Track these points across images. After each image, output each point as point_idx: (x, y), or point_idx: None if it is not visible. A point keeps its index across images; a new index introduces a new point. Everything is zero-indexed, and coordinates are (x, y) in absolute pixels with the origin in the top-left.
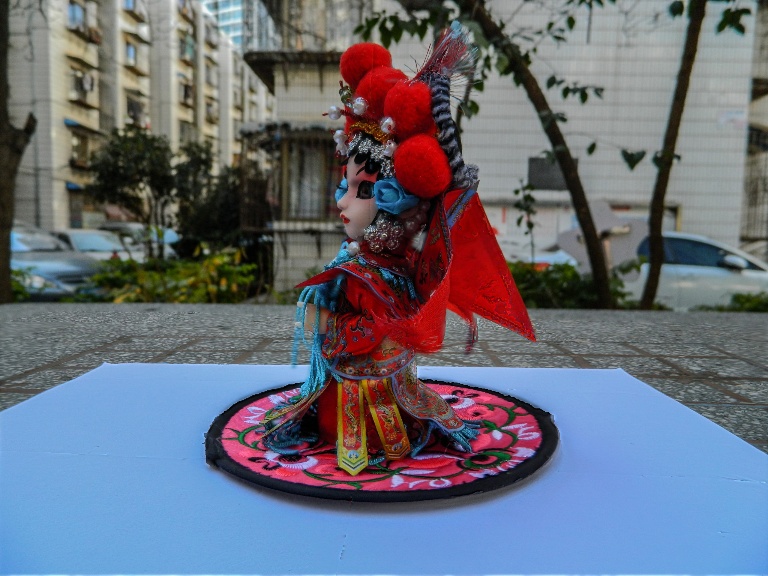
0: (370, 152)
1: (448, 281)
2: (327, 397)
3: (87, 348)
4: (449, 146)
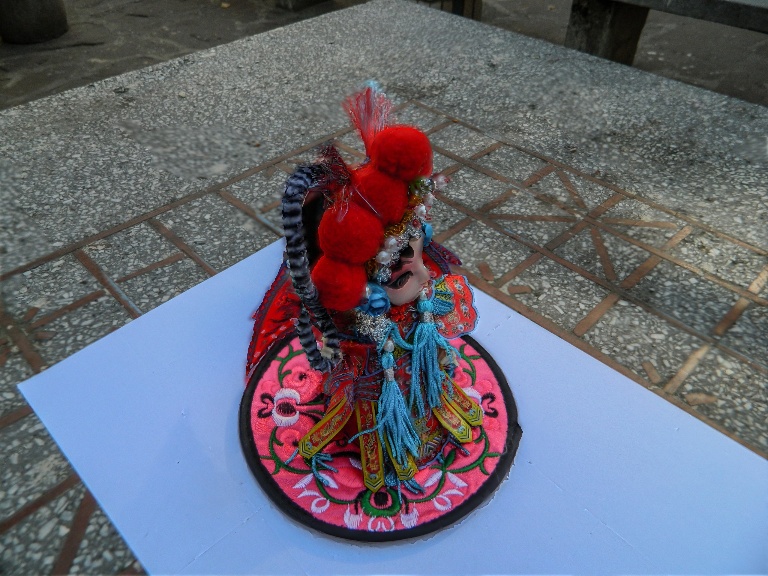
0: None
1: None
2: None
3: None
4: None
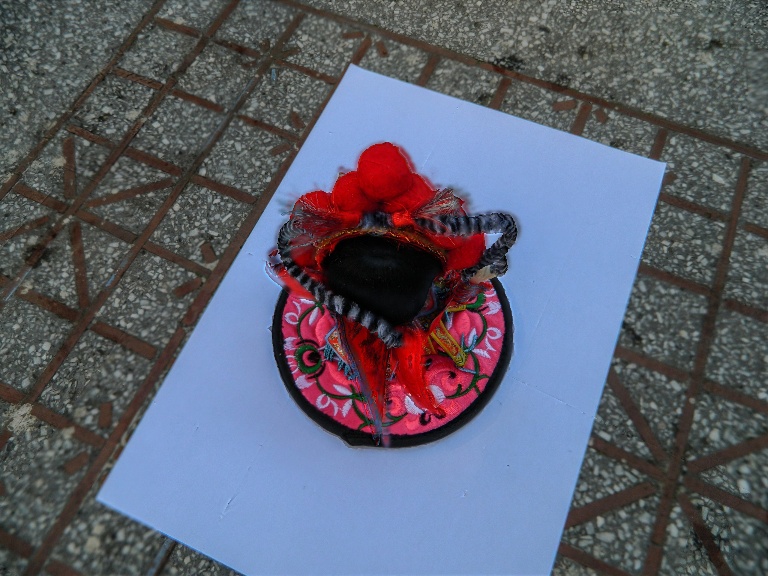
0: None
1: None
2: None
3: (763, 145)
4: None
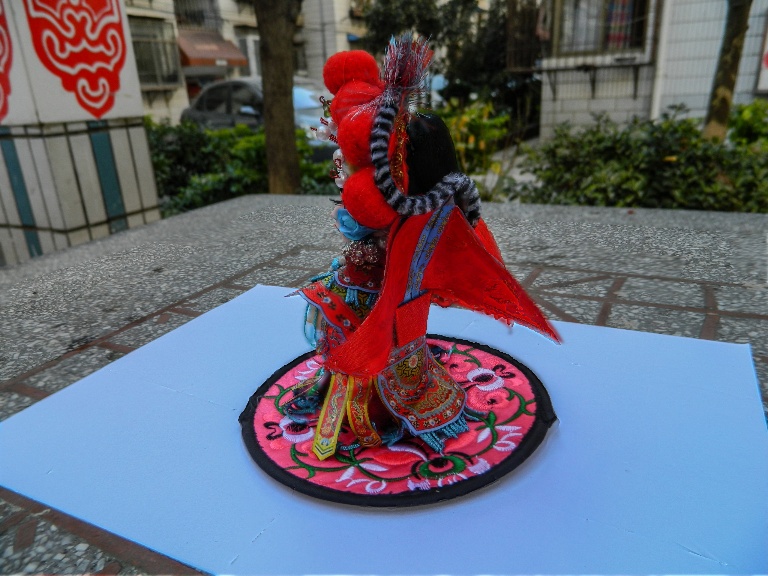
0: None
1: (367, 326)
2: (324, 384)
3: (261, 261)
4: (383, 186)
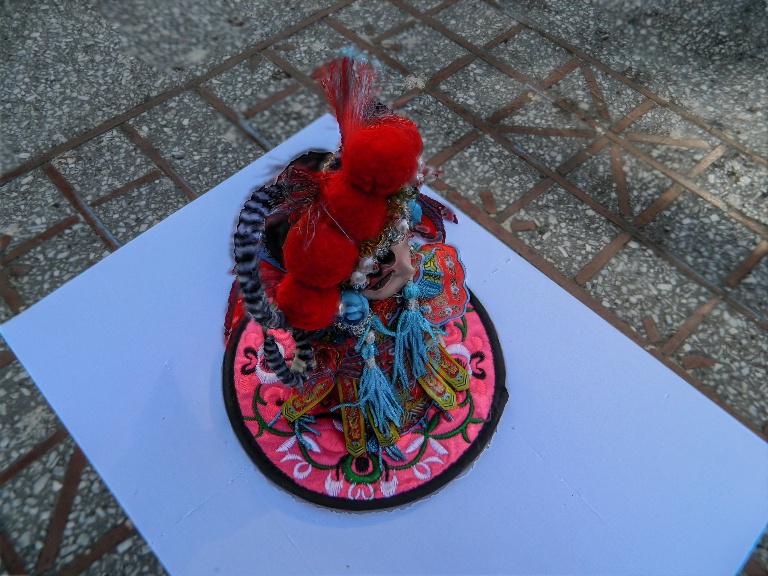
0: (409, 209)
1: None
2: None
3: None
4: None
